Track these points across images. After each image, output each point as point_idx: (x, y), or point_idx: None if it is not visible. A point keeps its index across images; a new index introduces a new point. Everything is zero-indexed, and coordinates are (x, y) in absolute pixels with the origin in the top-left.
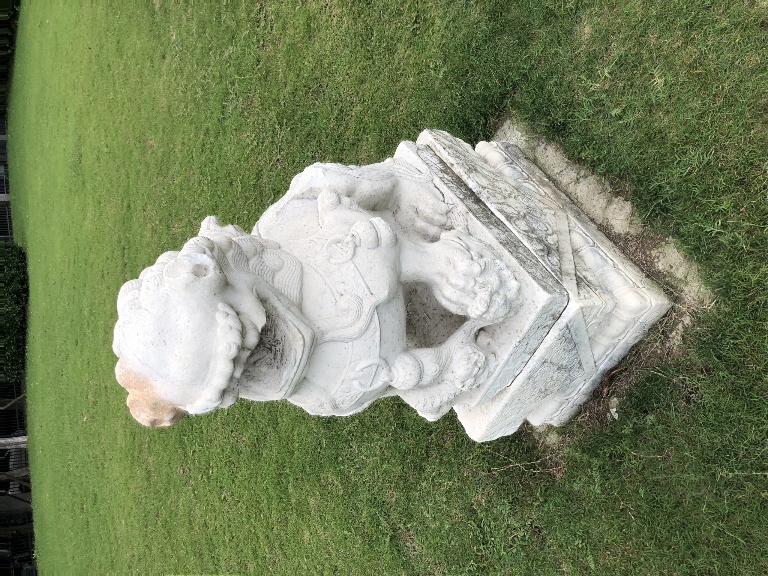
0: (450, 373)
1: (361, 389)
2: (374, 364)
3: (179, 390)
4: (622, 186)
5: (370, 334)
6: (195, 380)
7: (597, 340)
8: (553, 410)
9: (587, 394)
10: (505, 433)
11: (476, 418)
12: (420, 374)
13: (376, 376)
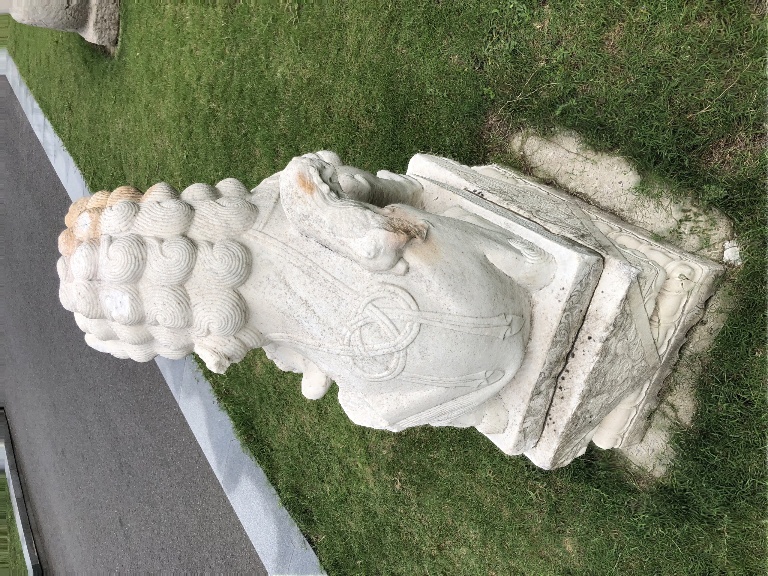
0: None
1: None
2: None
3: None
4: None
5: None
6: None
7: None
8: None
9: None
10: None
11: None
12: None
13: None
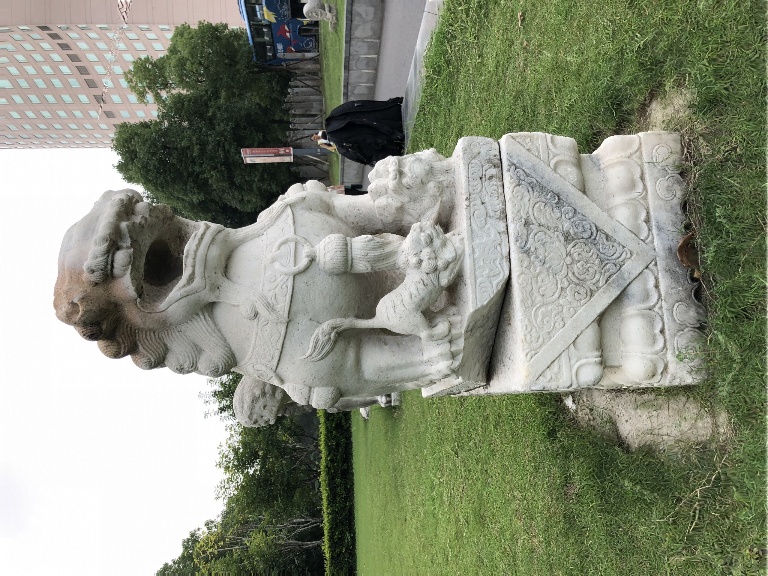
0: (402, 255)
1: (283, 269)
2: (290, 240)
3: (77, 250)
4: (604, 137)
5: (282, 220)
6: (87, 233)
7: (611, 206)
8: (642, 332)
9: (686, 302)
10: (579, 376)
11: (516, 358)
12: (344, 239)
13: (299, 257)
